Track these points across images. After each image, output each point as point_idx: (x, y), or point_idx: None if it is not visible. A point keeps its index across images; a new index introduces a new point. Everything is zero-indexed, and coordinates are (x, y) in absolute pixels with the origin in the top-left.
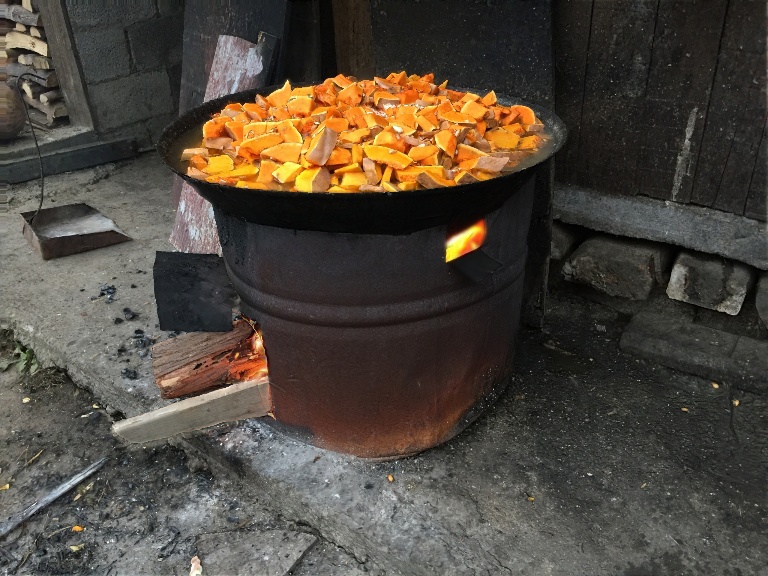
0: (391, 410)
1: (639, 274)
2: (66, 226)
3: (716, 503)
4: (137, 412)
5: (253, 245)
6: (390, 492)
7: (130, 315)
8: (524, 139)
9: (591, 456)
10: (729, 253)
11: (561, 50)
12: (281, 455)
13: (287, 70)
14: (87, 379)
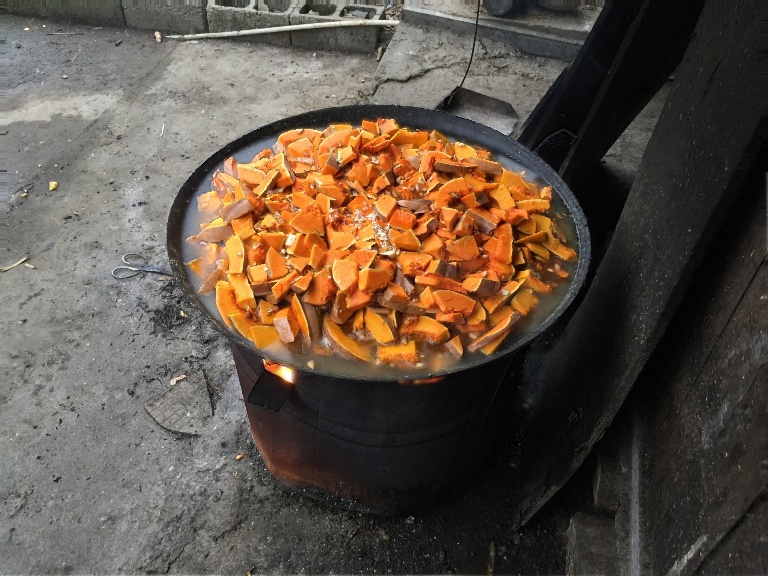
0: None
1: None
2: (481, 115)
3: None
4: None
5: None
6: (223, 461)
7: None
8: (407, 345)
9: None
10: None
11: (713, 307)
12: None
13: (564, 105)
14: None
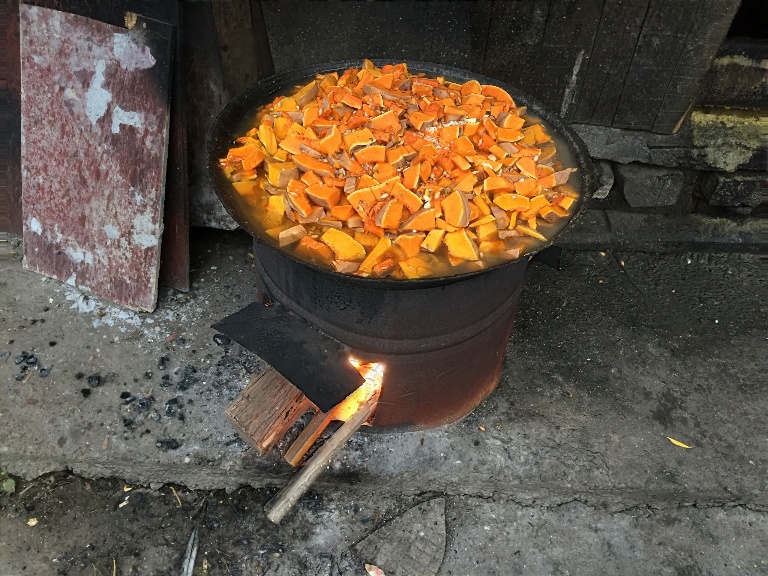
0: (479, 381)
1: None
2: None
3: (662, 345)
4: (199, 476)
5: (391, 307)
6: (492, 439)
7: (96, 381)
8: None
9: (579, 345)
10: (601, 156)
11: None
12: (390, 452)
13: None
14: (109, 469)
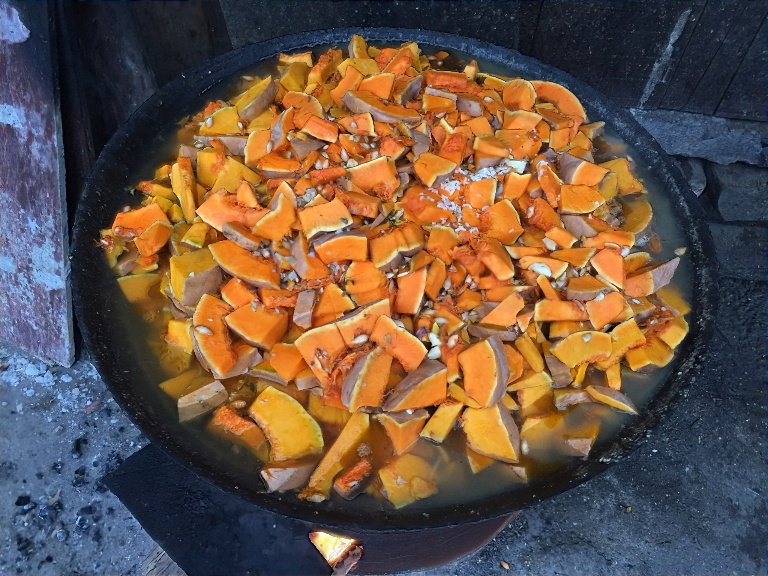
0: None
1: None
2: None
3: (756, 430)
4: None
5: None
6: None
7: None
8: (611, 168)
9: None
10: (692, 153)
11: None
12: None
13: None
14: None
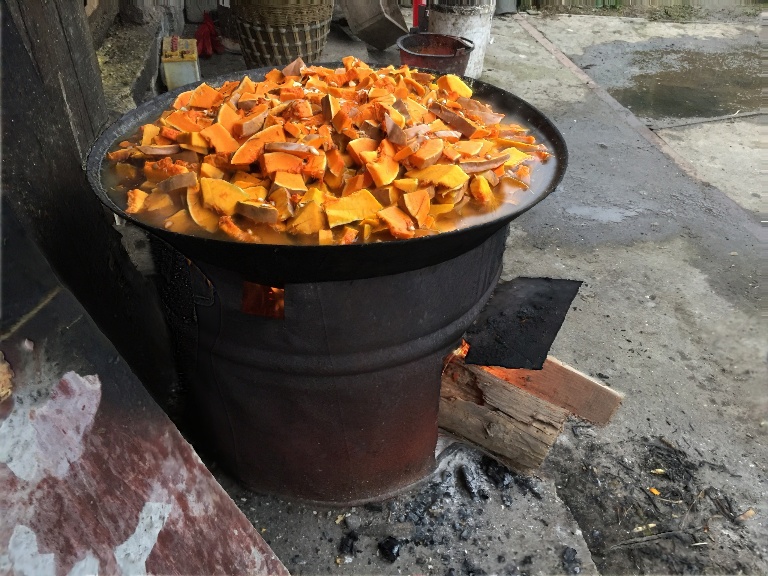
0: None
1: None
2: None
3: None
4: None
5: None
6: None
7: None
8: None
9: None
10: None
11: None
12: None
13: None
14: None
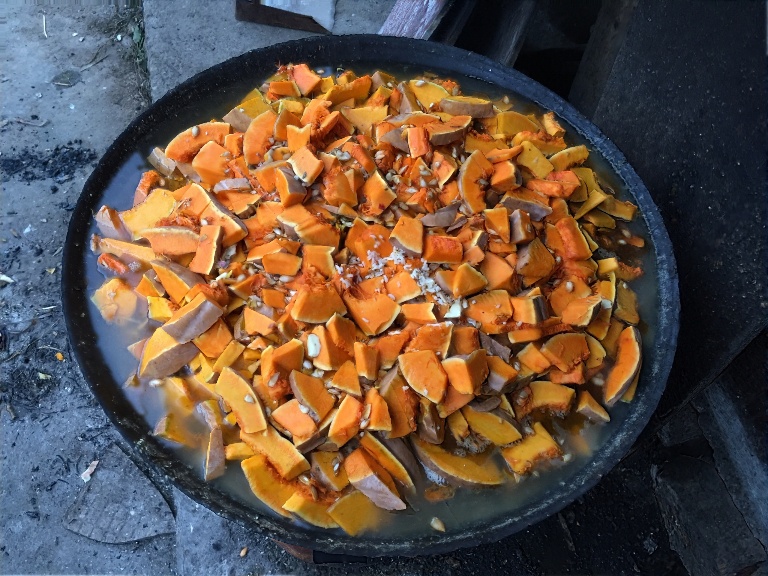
0: None
1: (713, 570)
2: None
3: None
4: None
5: None
6: (228, 567)
7: None
8: (538, 435)
9: None
10: None
11: None
12: None
13: None
14: None
